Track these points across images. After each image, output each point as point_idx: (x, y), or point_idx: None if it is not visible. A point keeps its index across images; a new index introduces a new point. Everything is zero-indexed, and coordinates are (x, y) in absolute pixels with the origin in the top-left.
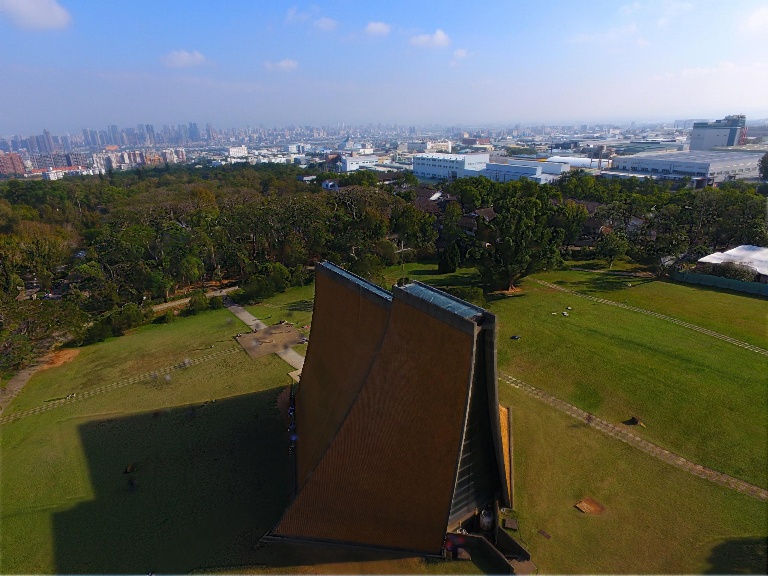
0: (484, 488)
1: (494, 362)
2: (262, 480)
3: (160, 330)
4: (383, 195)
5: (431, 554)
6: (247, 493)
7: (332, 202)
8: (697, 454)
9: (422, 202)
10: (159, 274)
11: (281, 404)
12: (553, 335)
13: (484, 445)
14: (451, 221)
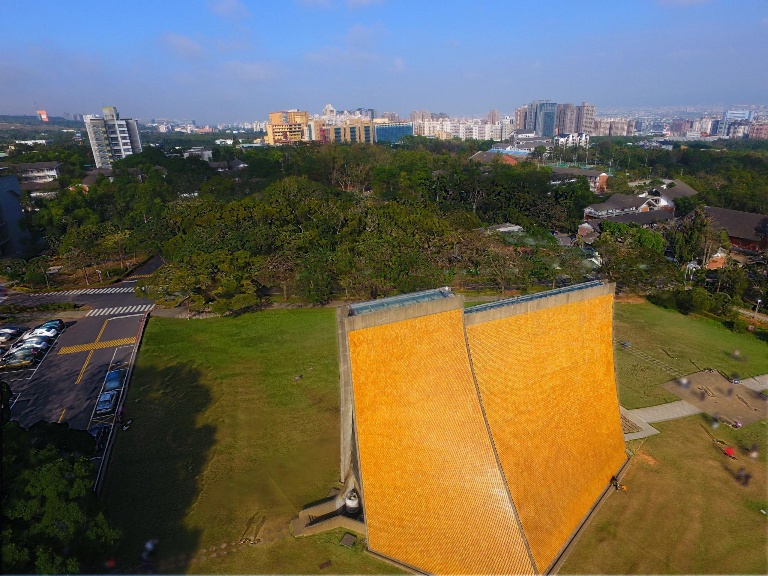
0: None
1: (347, 364)
2: None
3: (706, 328)
4: None
5: None
6: None
7: None
8: None
9: None
10: None
11: None
12: None
13: None
14: None
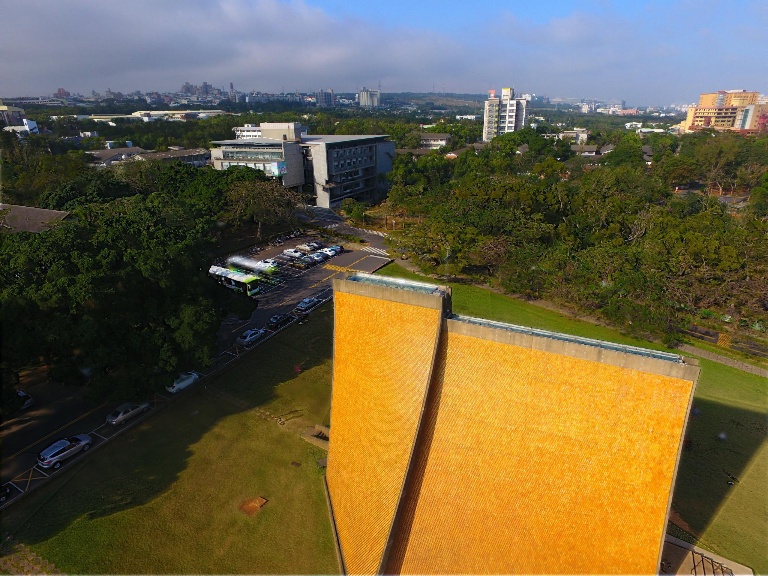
0: None
1: None
2: None
3: None
4: None
5: None
6: None
7: None
8: None
9: None
10: None
11: None
12: None
13: None
14: None
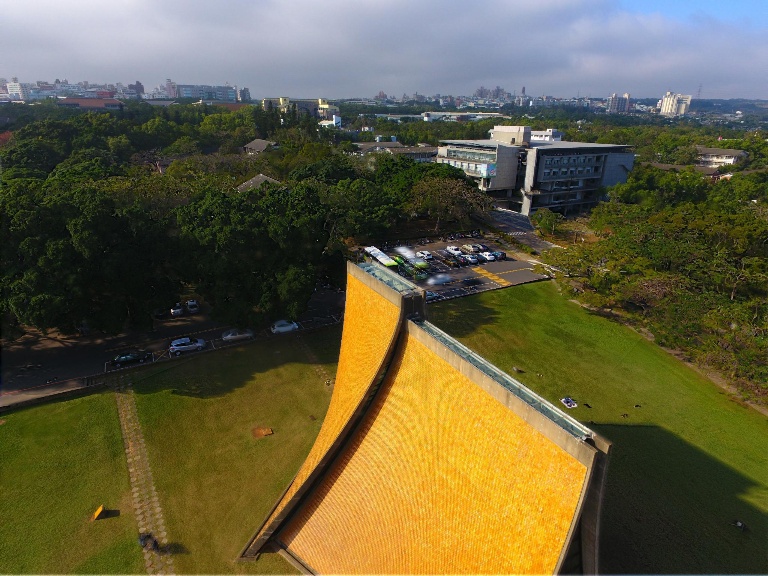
0: None
1: None
2: None
3: None
4: None
5: None
6: None
7: None
8: (109, 462)
9: None
10: None
11: None
12: None
13: None
14: None
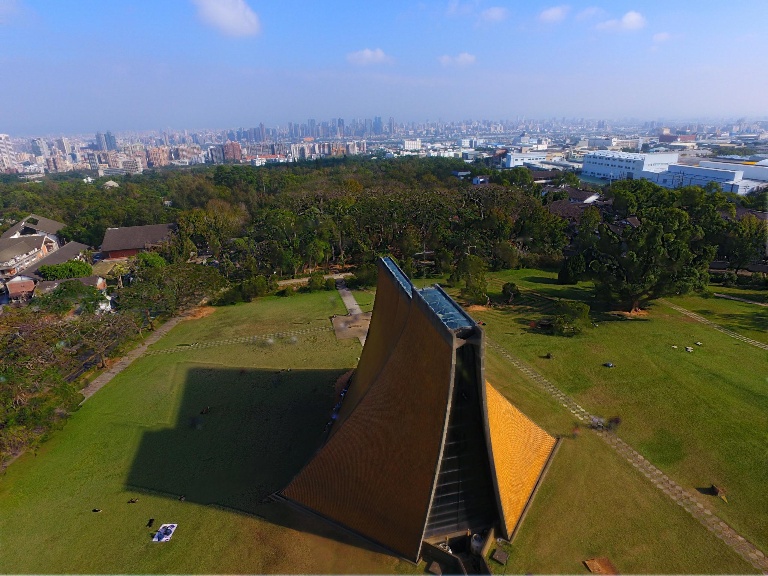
0: (479, 511)
1: (481, 380)
2: (293, 446)
3: (278, 302)
4: (516, 195)
5: (405, 558)
6: (277, 454)
7: (461, 199)
8: None
9: (563, 205)
10: (289, 253)
11: (339, 384)
12: (659, 371)
13: (478, 466)
14: (587, 228)
